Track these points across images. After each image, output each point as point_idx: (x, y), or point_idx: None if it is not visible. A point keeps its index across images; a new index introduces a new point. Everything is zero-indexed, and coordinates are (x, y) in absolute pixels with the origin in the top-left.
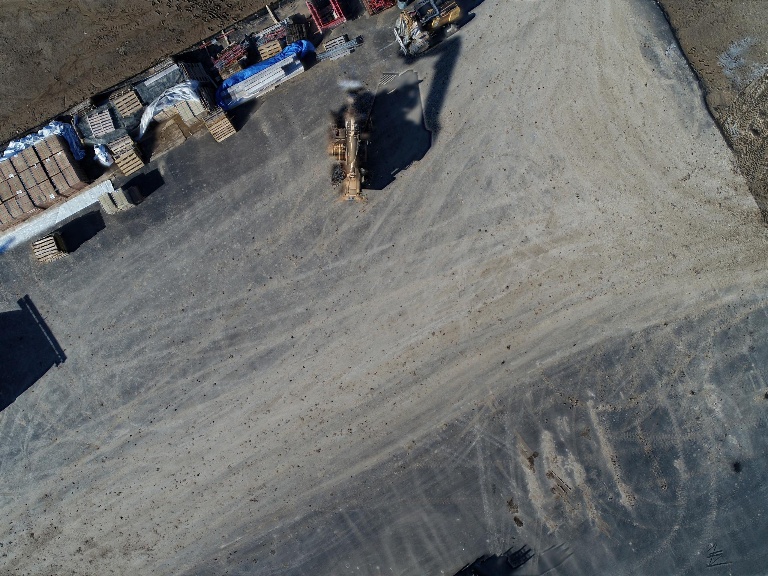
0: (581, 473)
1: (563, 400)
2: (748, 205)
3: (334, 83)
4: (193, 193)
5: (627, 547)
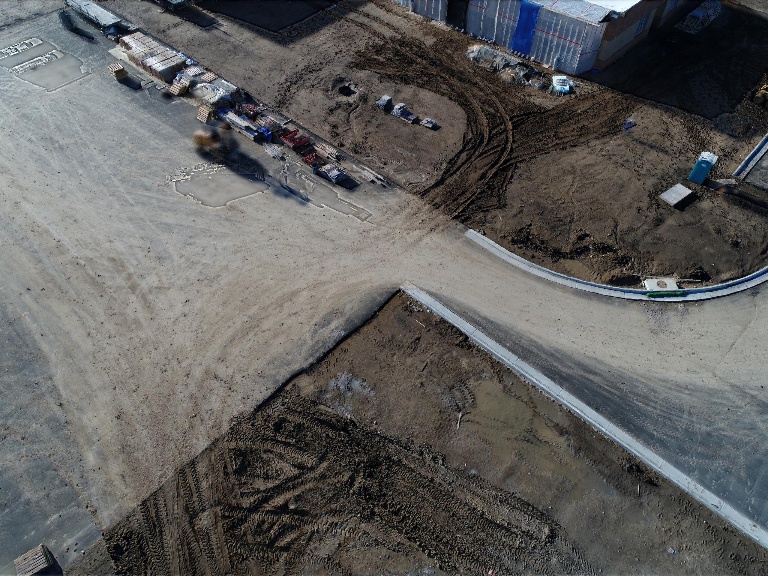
0: None
1: None
2: (198, 444)
3: (250, 155)
4: (162, 115)
5: None
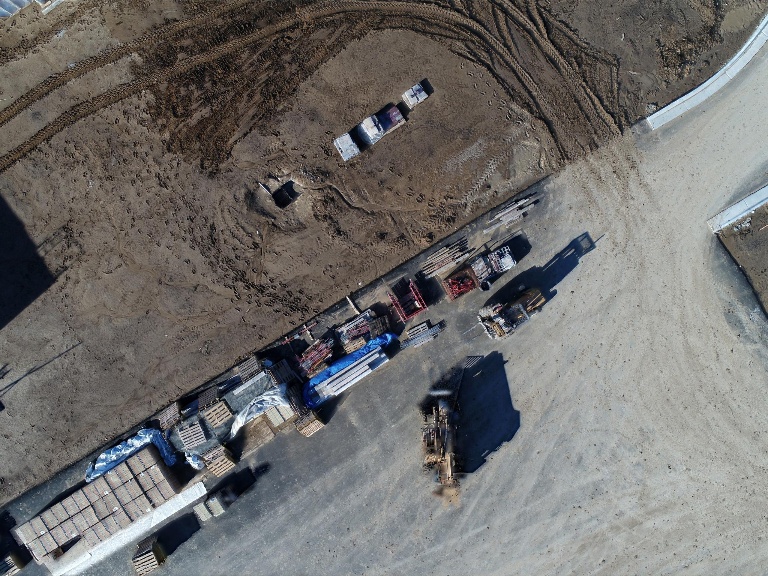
0: None
1: None
2: None
3: (419, 369)
4: (285, 488)
5: None
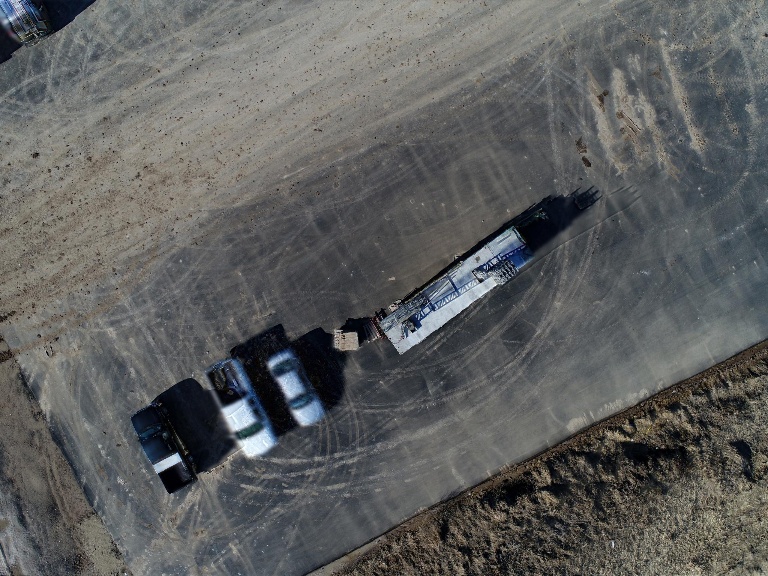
0: (651, 114)
1: (635, 37)
2: None
3: None
4: None
5: (696, 192)
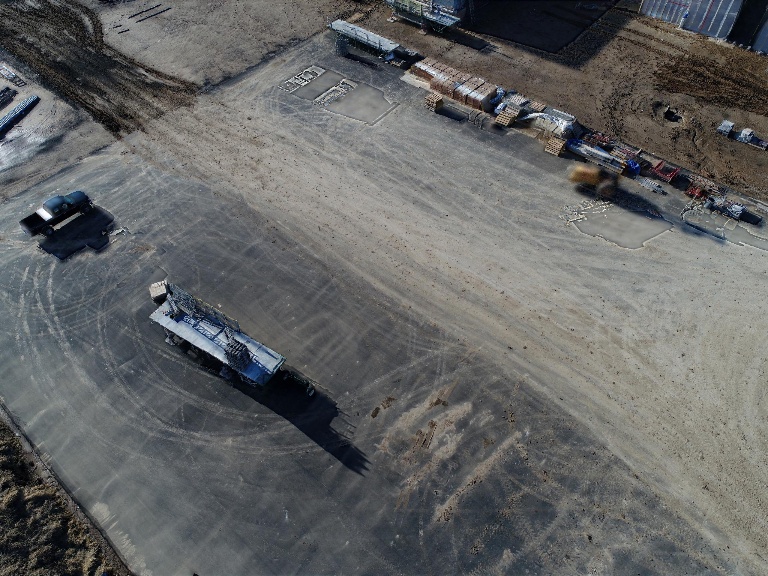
0: (448, 452)
1: (507, 408)
2: None
3: (627, 189)
4: (506, 149)
5: (392, 534)
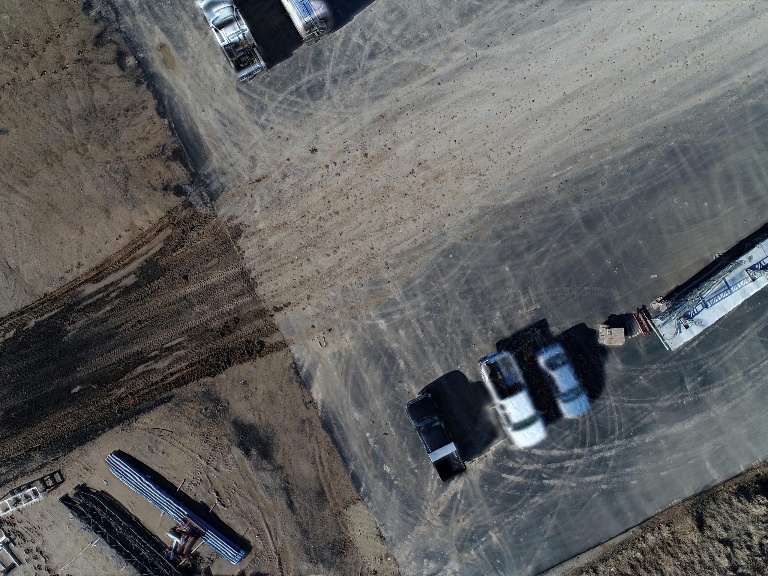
0: None
1: None
2: None
3: None
4: None
5: None
